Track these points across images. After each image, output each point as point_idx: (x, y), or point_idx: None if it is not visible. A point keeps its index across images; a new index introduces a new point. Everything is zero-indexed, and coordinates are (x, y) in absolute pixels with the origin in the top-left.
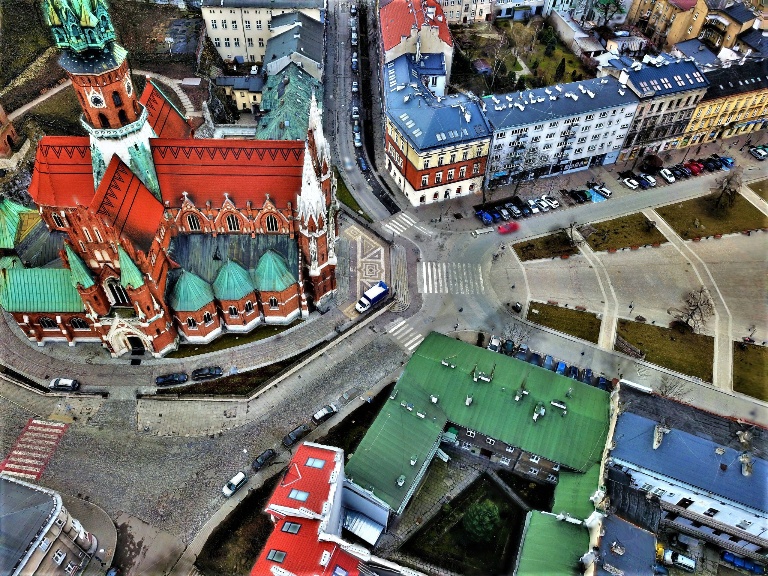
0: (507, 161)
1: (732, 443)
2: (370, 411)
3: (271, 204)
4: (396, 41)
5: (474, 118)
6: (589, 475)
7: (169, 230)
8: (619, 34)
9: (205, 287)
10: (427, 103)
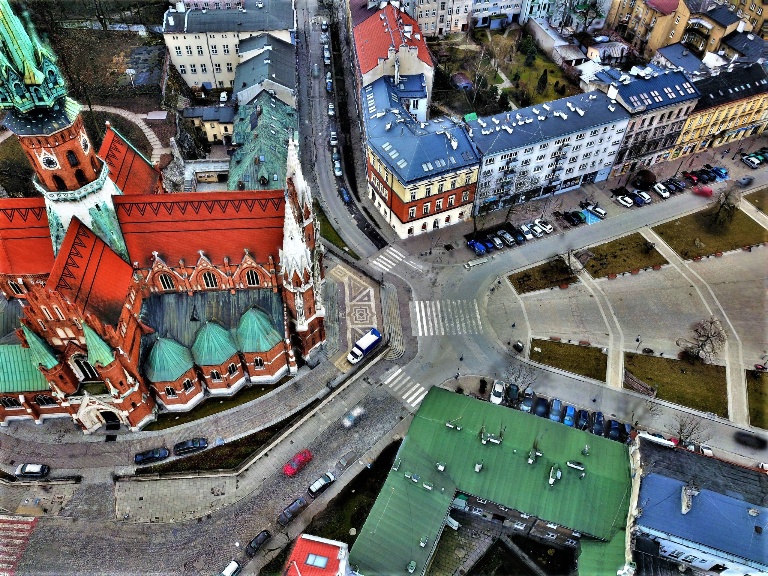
0: (497, 186)
1: (765, 501)
2: (371, 477)
3: (251, 259)
4: (373, 63)
5: (461, 144)
6: (614, 544)
7: (140, 292)
8: (599, 40)
9: (183, 353)
10: (410, 130)
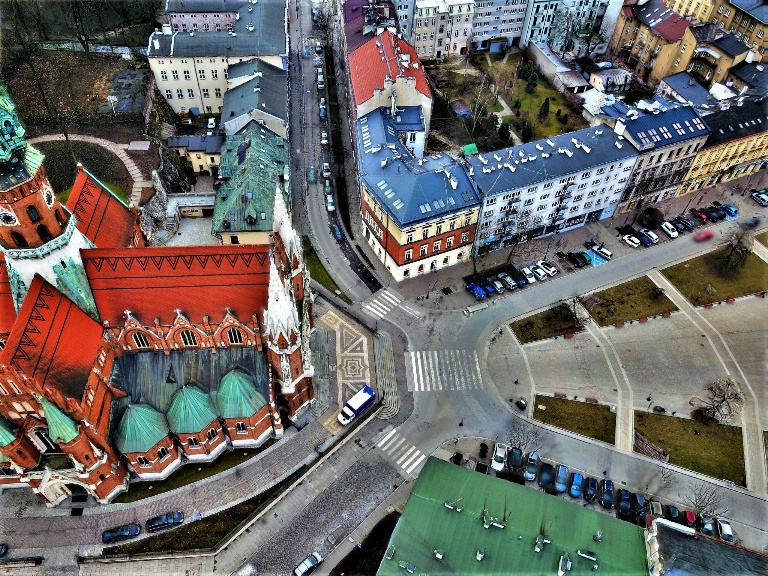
0: (498, 226)
1: None
2: (361, 558)
3: (233, 318)
4: (368, 94)
5: (461, 184)
6: None
7: (111, 351)
8: (601, 65)
9: (157, 419)
10: (407, 168)
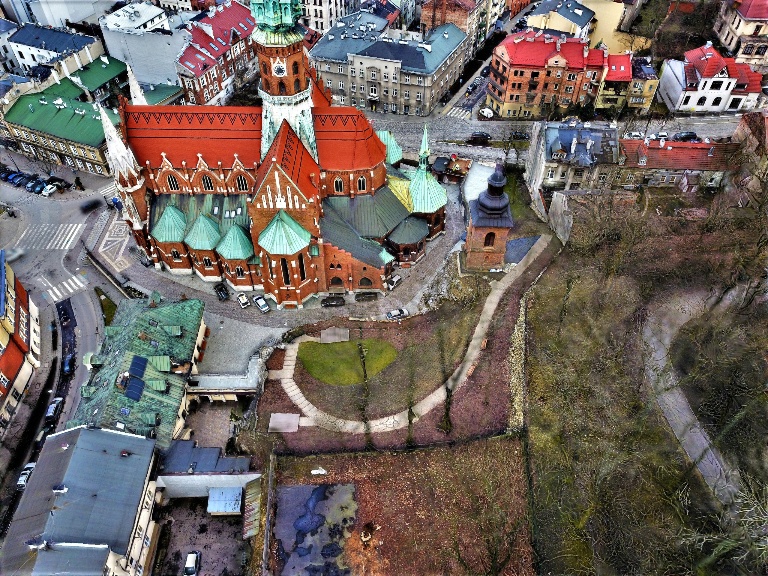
0: None
1: None
2: None
3: None
4: None
5: None
6: None
7: None
8: None
9: None
10: None
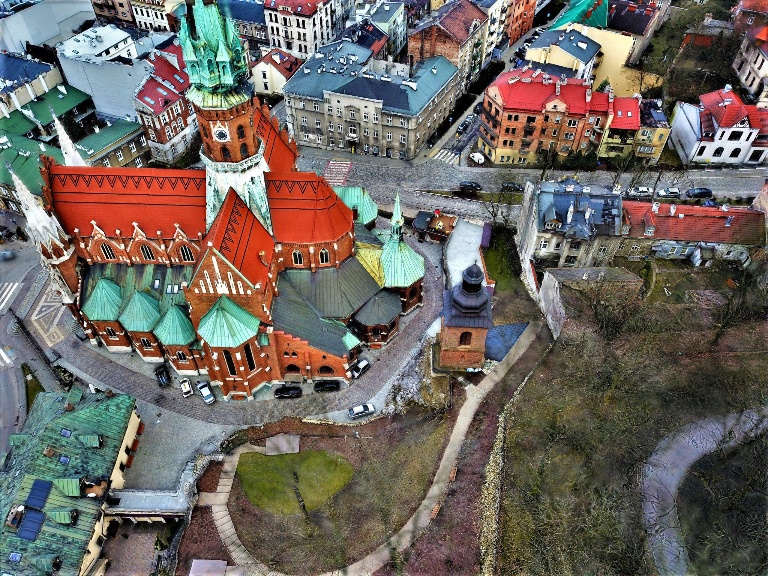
0: None
1: None
2: None
3: None
4: None
5: None
6: None
7: None
8: None
9: None
10: None
